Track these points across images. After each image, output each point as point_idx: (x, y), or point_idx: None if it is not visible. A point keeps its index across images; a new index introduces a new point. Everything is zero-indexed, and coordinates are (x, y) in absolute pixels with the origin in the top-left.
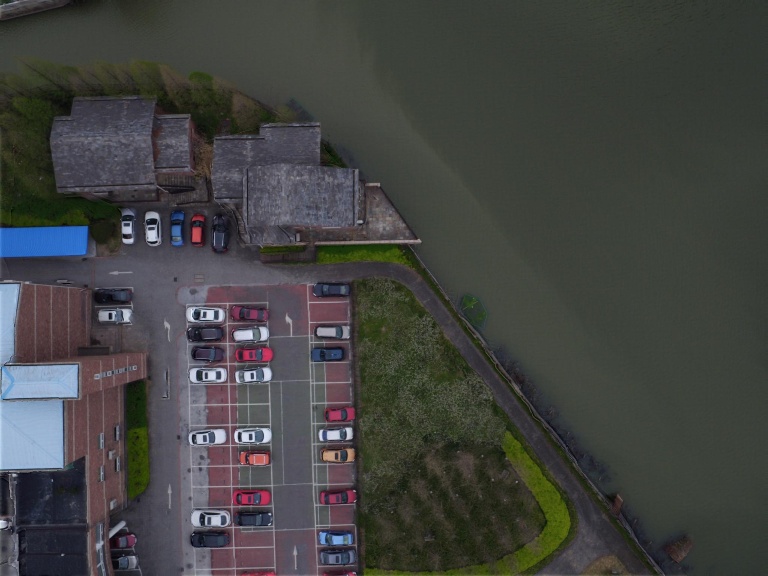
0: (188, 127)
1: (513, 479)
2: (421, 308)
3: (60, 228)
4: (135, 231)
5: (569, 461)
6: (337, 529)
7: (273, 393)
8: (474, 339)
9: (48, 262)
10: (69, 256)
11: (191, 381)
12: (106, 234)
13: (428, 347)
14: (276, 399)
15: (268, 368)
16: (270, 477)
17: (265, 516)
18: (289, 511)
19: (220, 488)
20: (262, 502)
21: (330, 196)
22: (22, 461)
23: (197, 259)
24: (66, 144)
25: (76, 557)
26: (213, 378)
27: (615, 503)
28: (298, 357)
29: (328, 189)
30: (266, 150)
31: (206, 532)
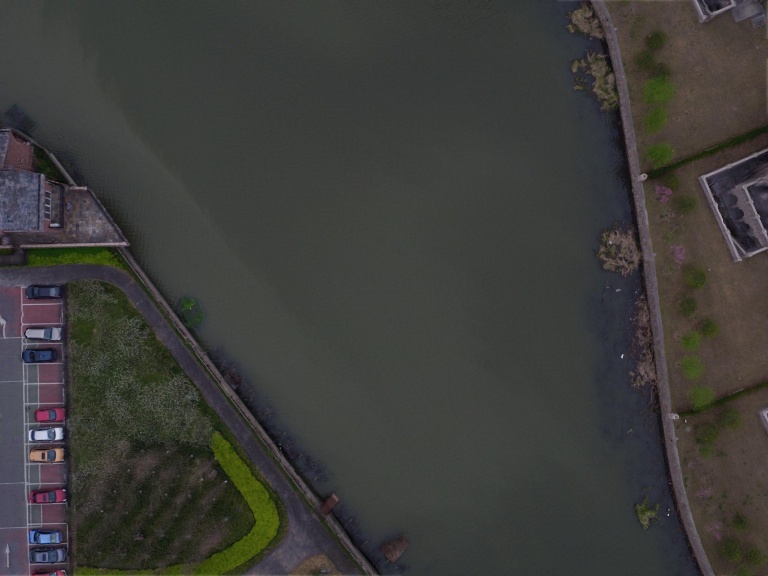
0: None
1: (222, 479)
2: (133, 310)
3: None
4: None
5: (276, 461)
6: (48, 528)
7: None
8: (184, 340)
9: None
10: None
11: None
12: None
13: (134, 348)
14: None
15: None
16: None
17: None
18: (2, 510)
19: None
20: None
21: (11, 200)
22: None
23: None
24: None
25: None
26: None
27: (326, 503)
28: (12, 358)
29: (9, 193)
30: None
31: None
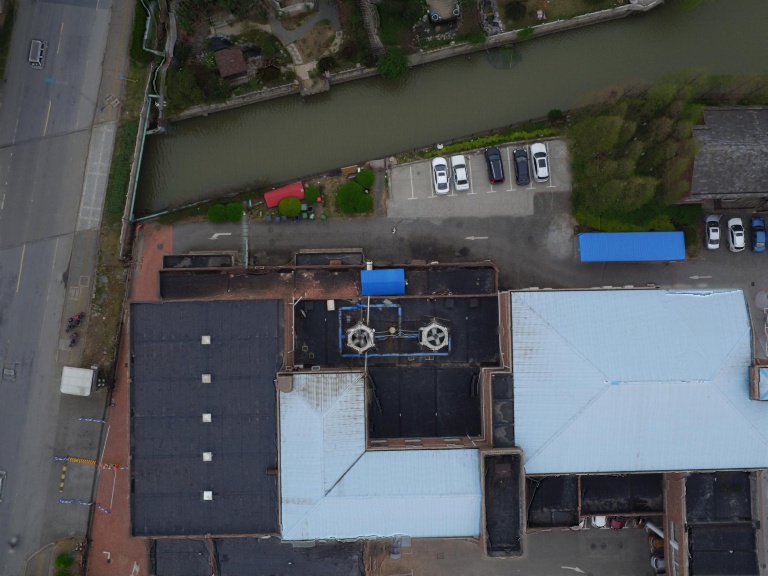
0: None
1: None
2: None
3: (660, 233)
4: (720, 237)
5: None
6: None
7: None
8: None
9: (641, 266)
10: None
11: None
12: (691, 239)
13: None
14: None
15: None
16: None
17: None
18: None
19: None
20: None
21: None
22: (752, 460)
23: None
24: (710, 152)
25: (742, 554)
26: None
27: None
28: None
29: None
30: None
31: None
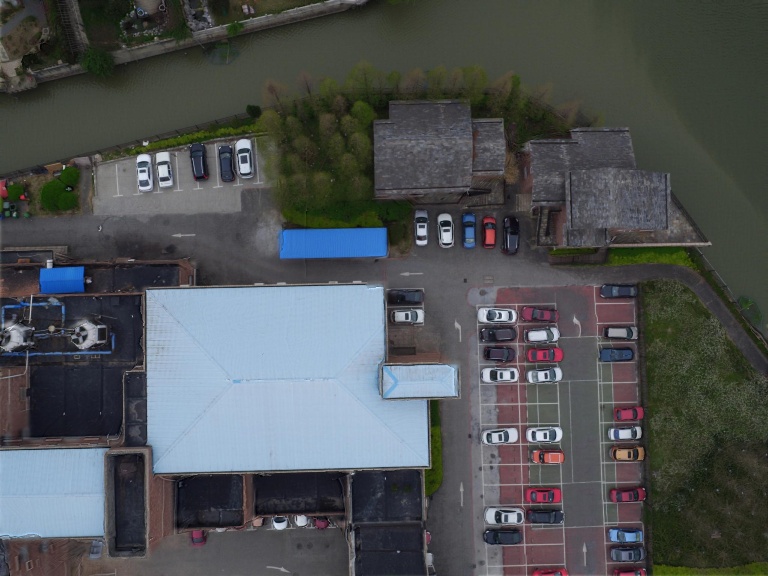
0: (503, 131)
1: None
2: (704, 309)
3: (361, 230)
4: (429, 233)
5: None
6: (626, 526)
7: (562, 393)
8: (757, 340)
9: (345, 263)
10: (369, 257)
11: (483, 381)
12: (399, 236)
13: (717, 348)
14: (565, 399)
15: (559, 368)
16: (559, 475)
17: (558, 514)
18: (578, 509)
19: (511, 486)
20: (555, 500)
21: (648, 199)
22: (389, 459)
23: (486, 261)
24: (389, 147)
25: (410, 554)
26: (508, 378)
27: None
28: (585, 357)
29: (646, 193)
30: (582, 154)
31: (500, 529)
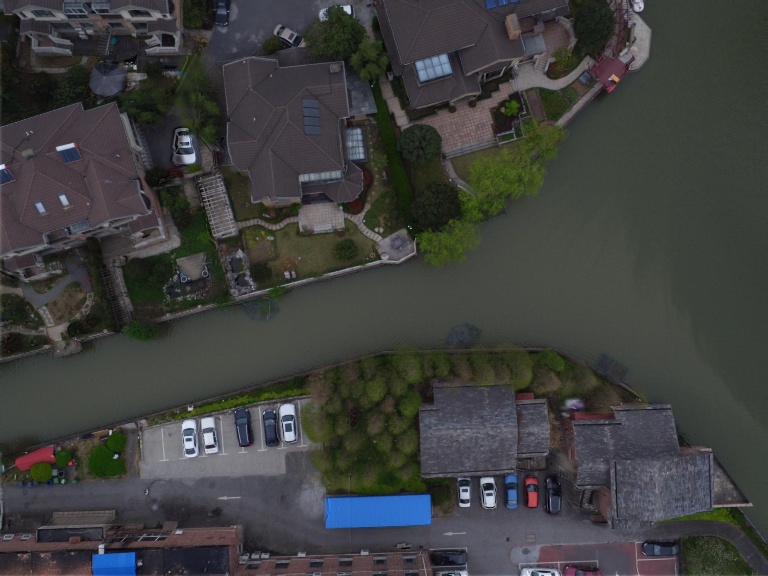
0: (547, 413)
1: None
2: (745, 564)
3: (405, 499)
4: (472, 495)
5: None
6: None
7: None
8: None
9: (390, 528)
10: (414, 525)
11: None
12: (442, 498)
13: None
14: None
15: None
16: None
17: None
18: None
19: None
20: None
21: (692, 485)
22: None
23: (528, 519)
24: (435, 436)
25: None
26: None
27: None
28: None
29: (691, 478)
30: (626, 437)
31: None
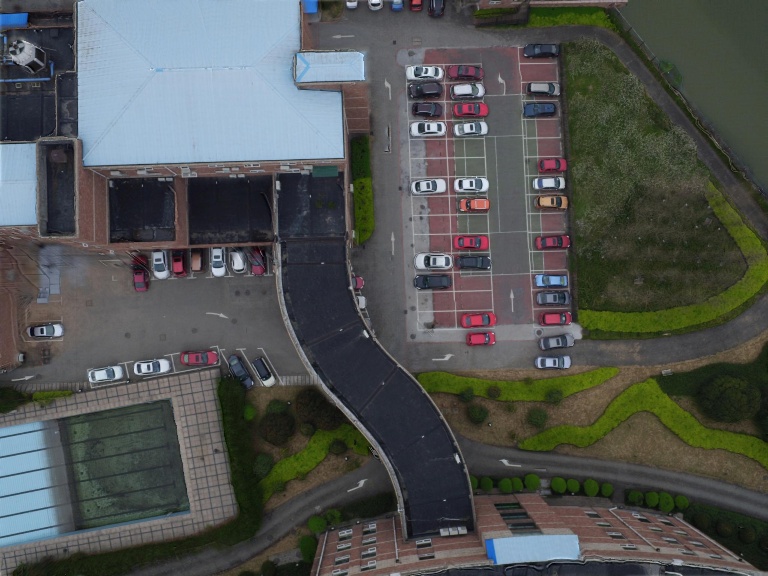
0: None
1: (716, 226)
2: (625, 69)
3: None
4: None
5: None
6: (551, 273)
7: (488, 147)
8: (676, 96)
9: None
10: None
11: (412, 135)
12: None
13: (636, 100)
14: (491, 153)
15: (484, 122)
16: (487, 225)
17: (485, 259)
18: (505, 257)
19: (440, 235)
20: (482, 246)
21: None
22: (306, 151)
23: (414, 24)
24: None
25: (334, 266)
26: (435, 129)
27: None
28: (511, 114)
29: None
30: None
31: (429, 275)
